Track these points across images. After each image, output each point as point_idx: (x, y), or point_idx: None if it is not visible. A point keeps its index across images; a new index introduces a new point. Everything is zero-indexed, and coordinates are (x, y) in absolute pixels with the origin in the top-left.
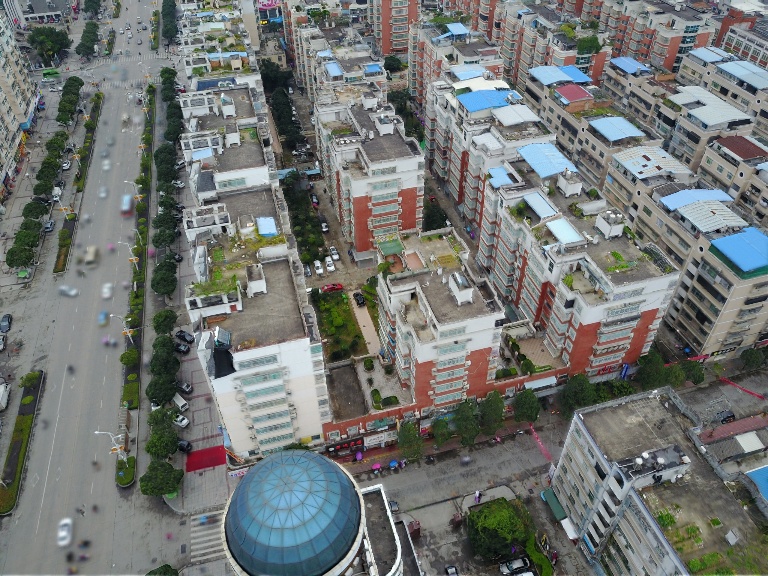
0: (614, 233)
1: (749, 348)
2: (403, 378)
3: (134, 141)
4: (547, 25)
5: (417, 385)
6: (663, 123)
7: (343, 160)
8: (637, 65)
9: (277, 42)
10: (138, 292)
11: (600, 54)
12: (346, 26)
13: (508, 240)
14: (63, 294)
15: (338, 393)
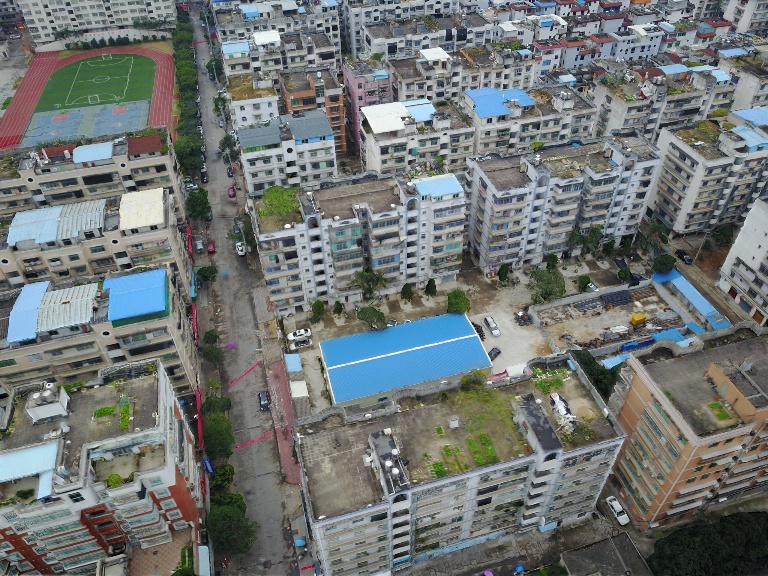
0: (65, 403)
1: None
2: None
3: None
4: None
5: None
6: None
7: None
8: None
9: None
10: None
11: None
12: None
13: None
14: None
15: None
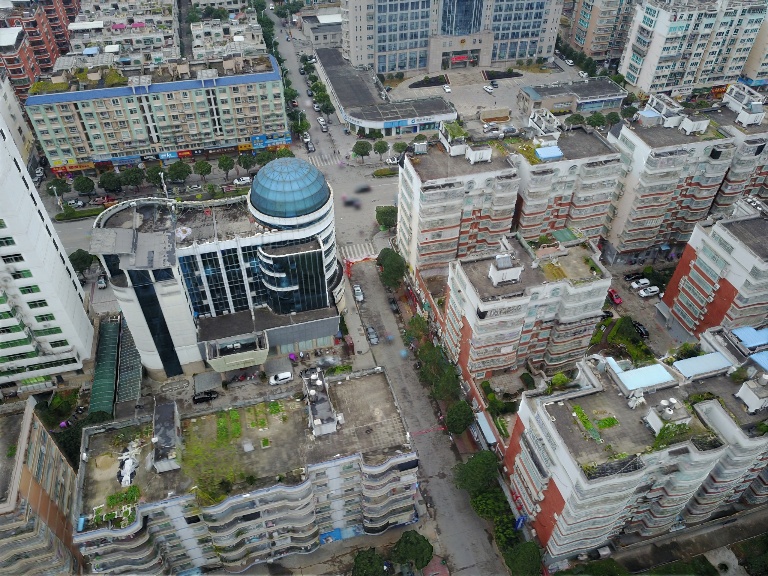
0: (652, 422)
1: None
2: None
3: None
4: None
5: None
6: None
7: (732, 215)
8: None
9: None
10: None
11: None
12: None
13: None
14: None
15: None
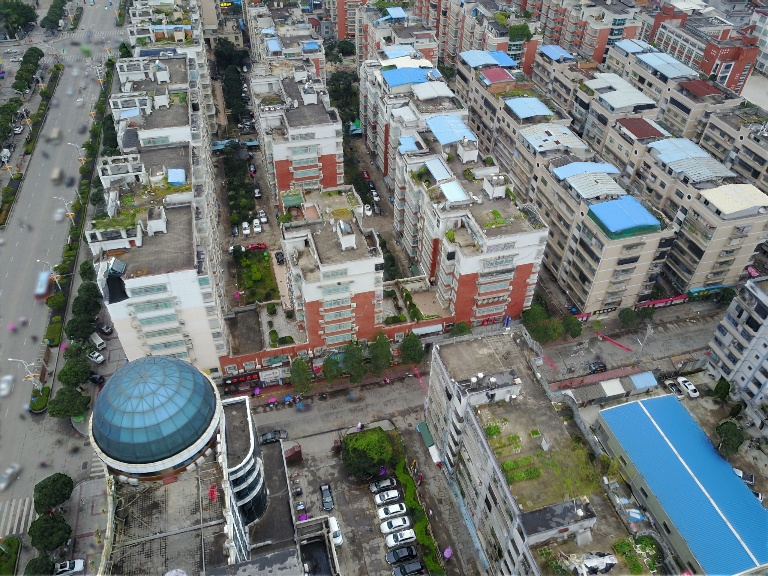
0: (497, 194)
1: (627, 308)
2: (298, 320)
3: (87, 110)
4: (485, 13)
5: (307, 324)
6: (579, 106)
7: (267, 126)
8: (562, 53)
9: (236, 22)
10: (72, 245)
11: (531, 42)
12: (294, 7)
13: (411, 202)
14: (1, 245)
15: (240, 333)
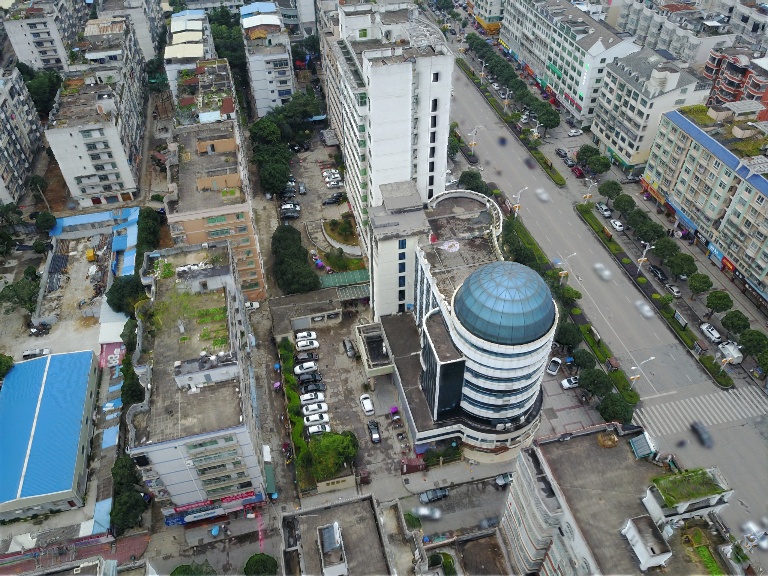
0: None
1: None
2: None
3: None
4: None
5: None
6: None
7: None
8: None
9: None
10: None
11: None
12: None
13: None
14: None
15: None
